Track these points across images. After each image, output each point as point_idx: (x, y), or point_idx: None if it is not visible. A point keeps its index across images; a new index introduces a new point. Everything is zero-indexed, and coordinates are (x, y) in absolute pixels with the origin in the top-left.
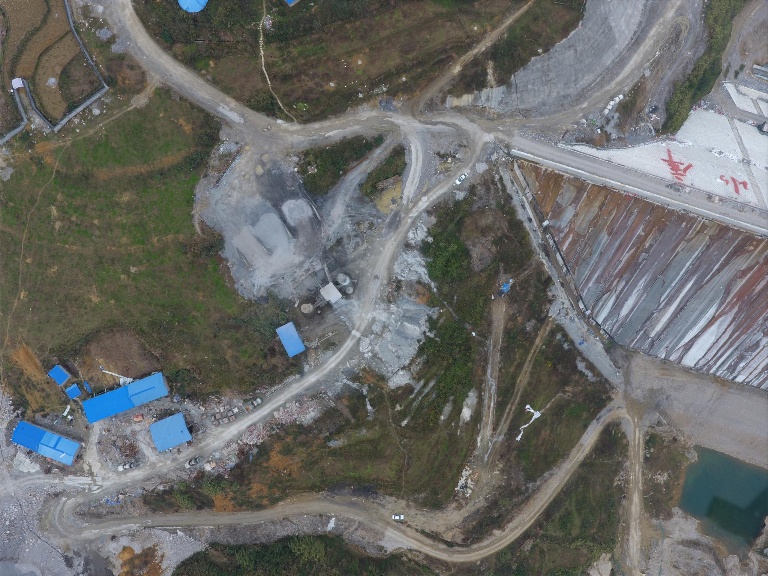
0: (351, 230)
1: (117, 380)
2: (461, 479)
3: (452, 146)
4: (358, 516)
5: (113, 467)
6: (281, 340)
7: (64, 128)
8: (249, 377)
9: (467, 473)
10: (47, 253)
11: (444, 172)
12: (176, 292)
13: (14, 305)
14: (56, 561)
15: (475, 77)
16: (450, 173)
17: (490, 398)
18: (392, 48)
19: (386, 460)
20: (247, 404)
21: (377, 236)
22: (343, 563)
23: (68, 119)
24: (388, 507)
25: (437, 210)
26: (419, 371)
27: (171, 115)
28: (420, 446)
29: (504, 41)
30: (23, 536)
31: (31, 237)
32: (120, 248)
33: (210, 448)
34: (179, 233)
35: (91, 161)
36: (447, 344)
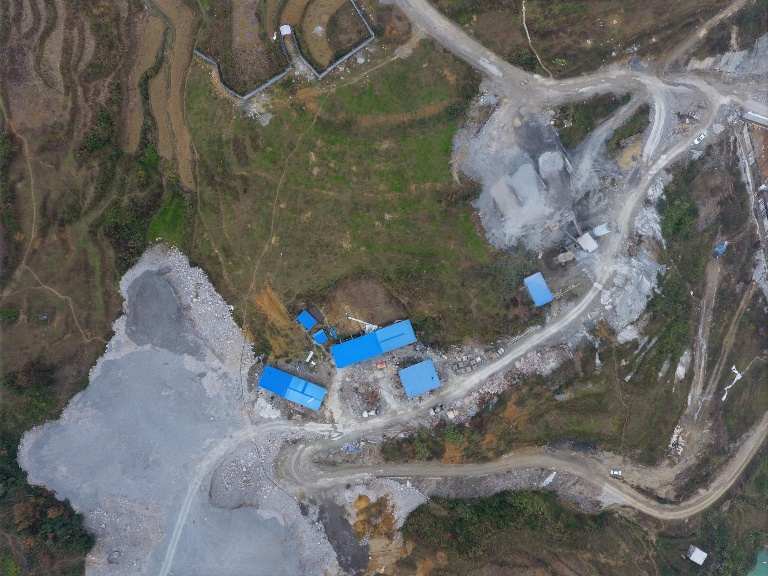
0: (598, 184)
1: (363, 327)
2: (673, 437)
3: (692, 107)
4: (577, 471)
5: (354, 414)
6: (529, 290)
7: (329, 75)
8: (493, 326)
9: (678, 431)
10: (302, 198)
11: (682, 132)
12: (429, 240)
13: (264, 250)
14: (293, 508)
15: (722, 40)
16: (688, 133)
17: (701, 358)
18: (646, 9)
19: (609, 415)
20: (488, 354)
21: (618, 192)
22: (563, 517)
23: (333, 66)
24: (606, 463)
25: (675, 168)
26: (647, 327)
27: (436, 66)
28: (640, 402)
29: (752, 7)
30: (260, 483)
31: (288, 182)
32: (377, 195)
33: (451, 397)
34: (437, 181)
35: (355, 108)
36: (671, 301)
